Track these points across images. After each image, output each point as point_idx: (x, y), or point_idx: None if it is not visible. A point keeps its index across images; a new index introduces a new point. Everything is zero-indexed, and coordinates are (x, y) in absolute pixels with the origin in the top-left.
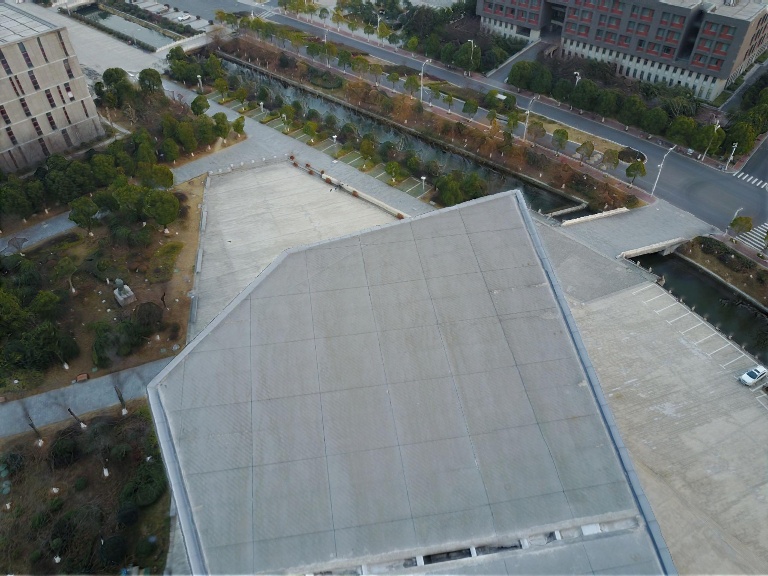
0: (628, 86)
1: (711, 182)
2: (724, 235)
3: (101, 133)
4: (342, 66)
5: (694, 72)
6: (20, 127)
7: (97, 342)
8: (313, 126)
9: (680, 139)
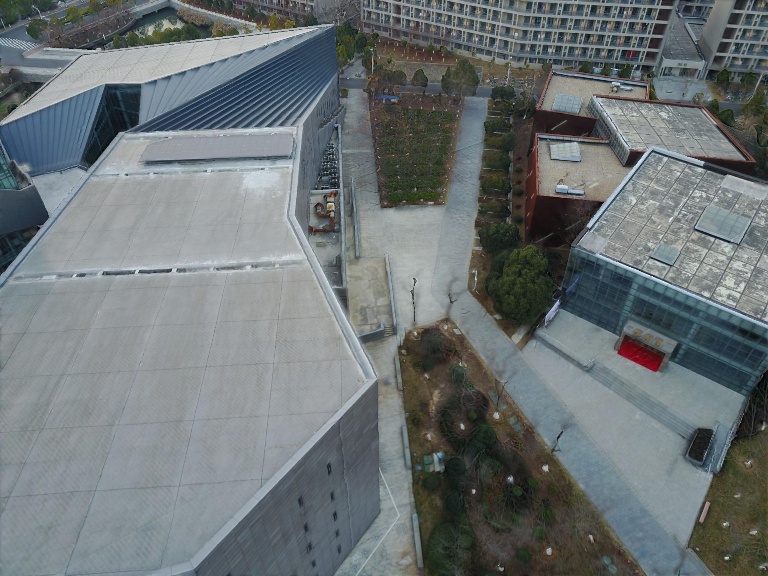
0: None
1: None
2: None
3: None
4: None
5: None
6: None
7: None
8: None
9: None
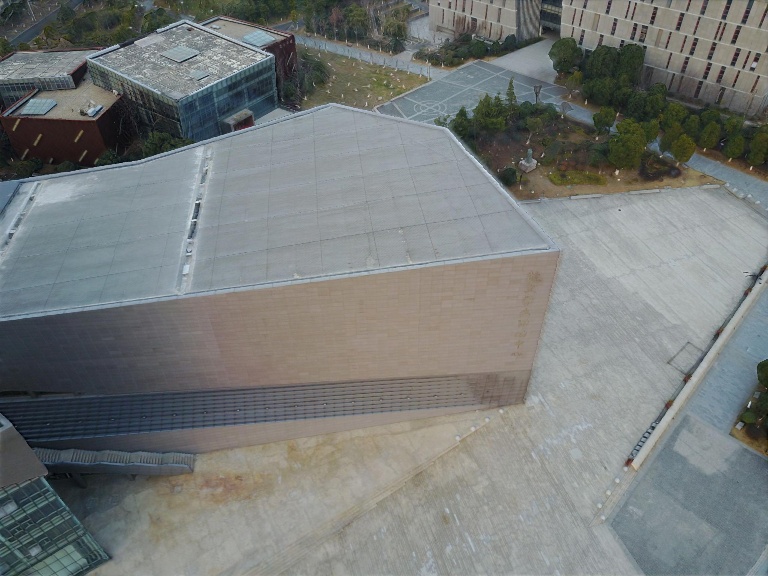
0: None
1: None
2: None
3: (750, 113)
4: None
5: None
6: (696, 63)
7: None
8: None
9: None
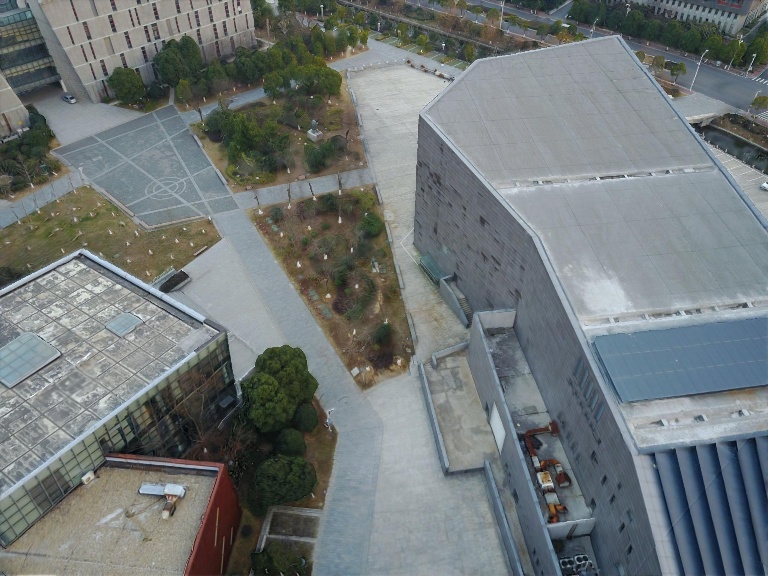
0: (666, 21)
1: (735, 83)
2: (747, 113)
3: (255, 43)
4: (432, 4)
5: (720, 10)
6: (205, 30)
7: (312, 154)
8: (425, 38)
9: (711, 53)
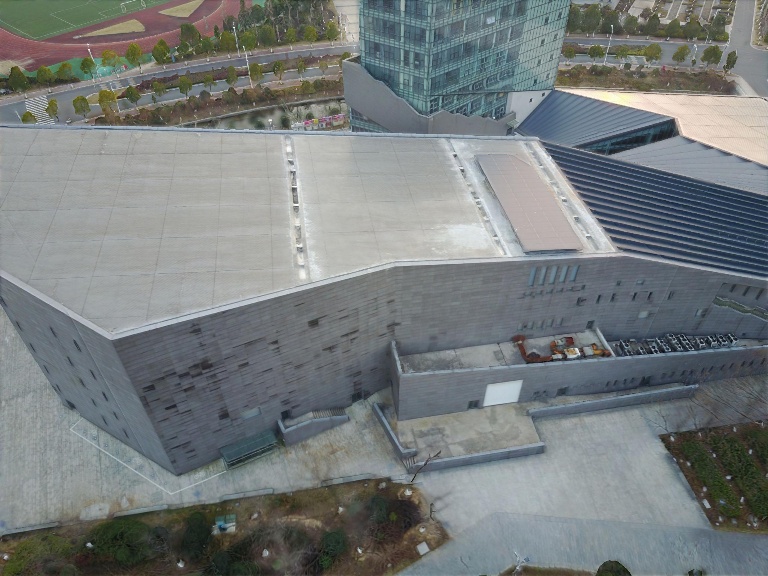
0: None
1: None
2: None
3: None
4: None
5: None
6: None
7: None
8: None
9: None
